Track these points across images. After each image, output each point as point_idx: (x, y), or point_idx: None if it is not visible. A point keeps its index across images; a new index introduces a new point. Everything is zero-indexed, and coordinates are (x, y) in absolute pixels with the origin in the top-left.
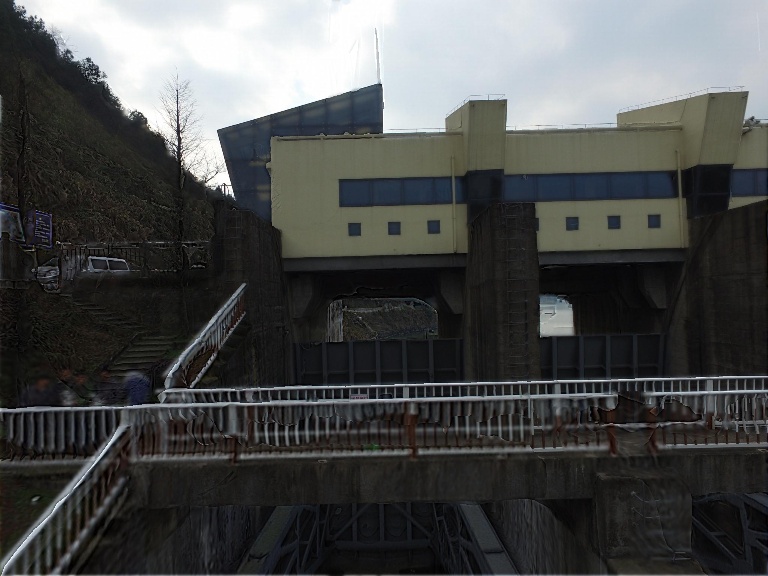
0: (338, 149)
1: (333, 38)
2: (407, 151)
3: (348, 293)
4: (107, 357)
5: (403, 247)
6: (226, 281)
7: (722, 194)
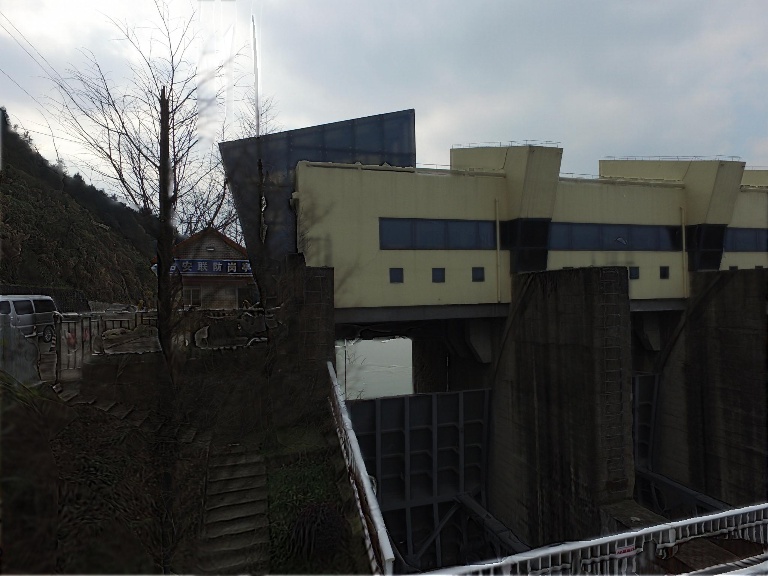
0: (378, 182)
1: (204, 18)
2: (451, 190)
3: (351, 336)
4: (197, 502)
5: (447, 296)
6: (305, 360)
7: (717, 250)
